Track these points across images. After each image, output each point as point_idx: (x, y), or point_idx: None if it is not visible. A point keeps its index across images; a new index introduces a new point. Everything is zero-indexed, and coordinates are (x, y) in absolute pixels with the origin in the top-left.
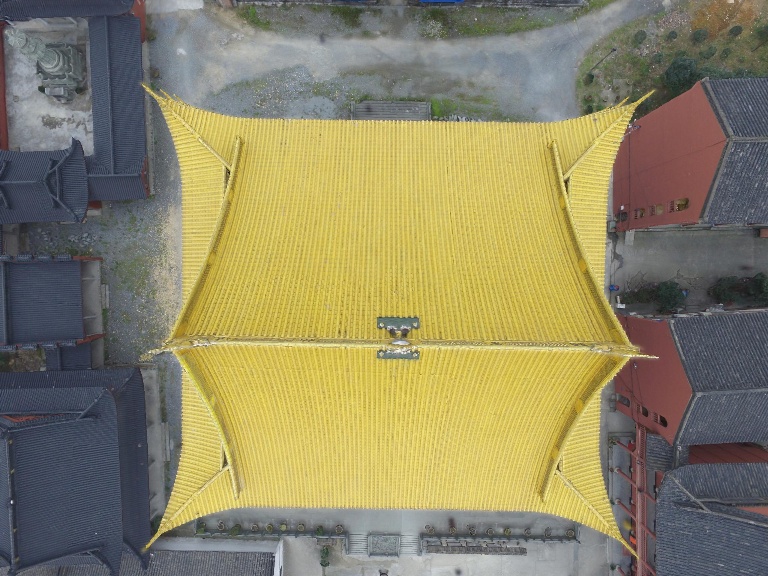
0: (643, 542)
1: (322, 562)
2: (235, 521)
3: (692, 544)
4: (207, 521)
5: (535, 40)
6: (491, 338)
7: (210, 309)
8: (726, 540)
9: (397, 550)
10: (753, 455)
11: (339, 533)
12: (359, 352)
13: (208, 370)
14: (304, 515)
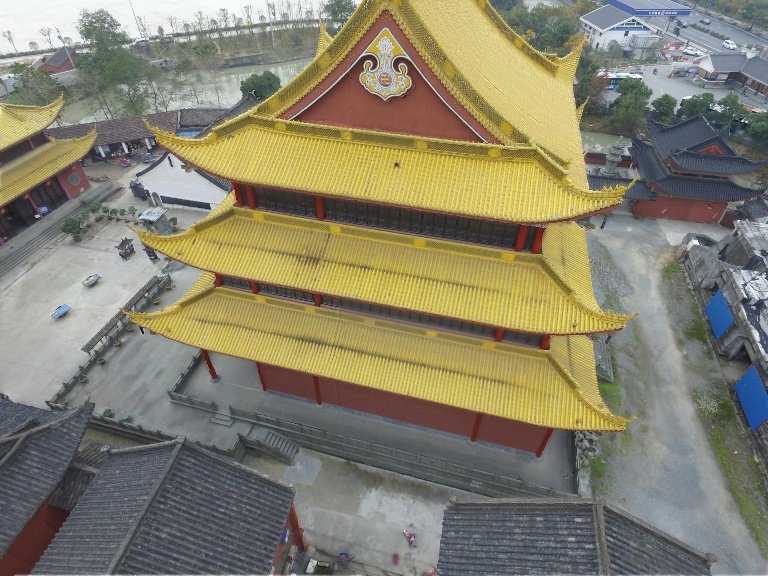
0: None
1: None
2: None
3: None
4: None
5: (732, 525)
6: None
7: None
8: None
9: None
10: None
11: None
12: None
13: None
14: None
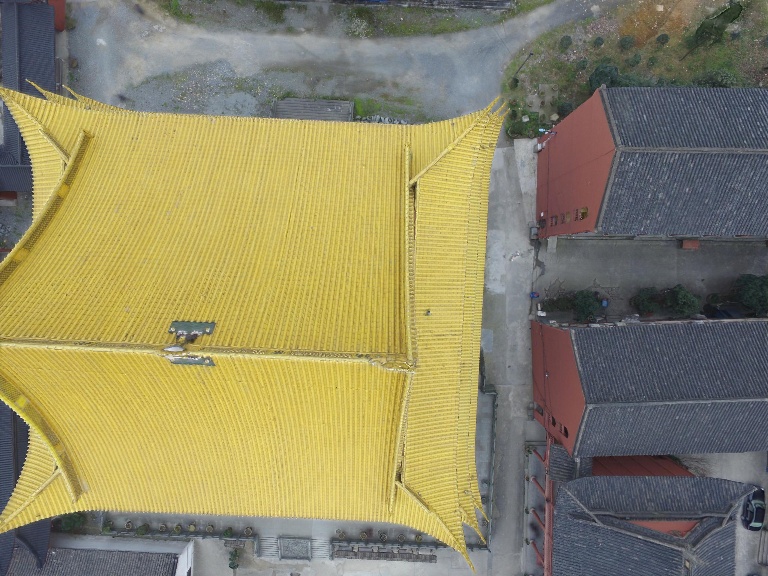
0: (549, 553)
1: (230, 564)
2: (143, 520)
3: (586, 557)
4: (115, 520)
5: (461, 42)
6: (281, 346)
7: (2, 308)
8: (617, 554)
9: (309, 554)
10: (662, 468)
11: (248, 535)
12: (151, 357)
13: (8, 370)
14: (214, 516)
